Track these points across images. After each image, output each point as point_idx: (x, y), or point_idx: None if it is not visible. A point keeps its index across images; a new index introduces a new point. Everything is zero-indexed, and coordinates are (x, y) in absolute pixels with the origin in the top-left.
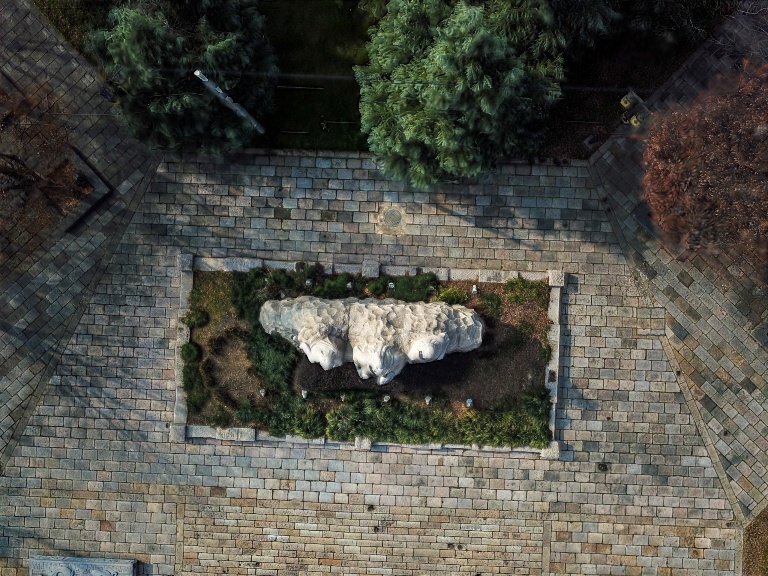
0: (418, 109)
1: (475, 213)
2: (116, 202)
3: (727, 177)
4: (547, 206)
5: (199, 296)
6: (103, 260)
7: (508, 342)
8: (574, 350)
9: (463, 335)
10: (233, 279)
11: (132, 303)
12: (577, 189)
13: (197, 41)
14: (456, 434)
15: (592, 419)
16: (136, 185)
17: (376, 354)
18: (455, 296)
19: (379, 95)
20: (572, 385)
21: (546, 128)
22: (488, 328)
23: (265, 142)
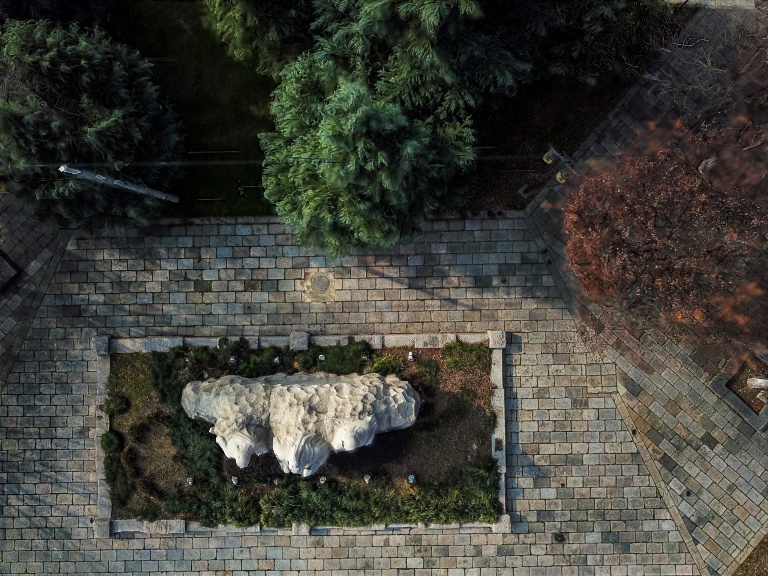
0: (321, 183)
1: (408, 274)
2: (25, 284)
3: (646, 253)
4: (484, 262)
5: (117, 381)
6: (14, 347)
7: (450, 411)
8: (522, 414)
9: (394, 414)
10: (153, 360)
11: (47, 391)
12: (514, 242)
13: (81, 121)
14: (399, 513)
15: (545, 487)
16: (45, 265)
17: (293, 449)
18: (390, 365)
19: (283, 166)
20: (522, 451)
21: (475, 182)
22: (427, 397)
23: (180, 212)
